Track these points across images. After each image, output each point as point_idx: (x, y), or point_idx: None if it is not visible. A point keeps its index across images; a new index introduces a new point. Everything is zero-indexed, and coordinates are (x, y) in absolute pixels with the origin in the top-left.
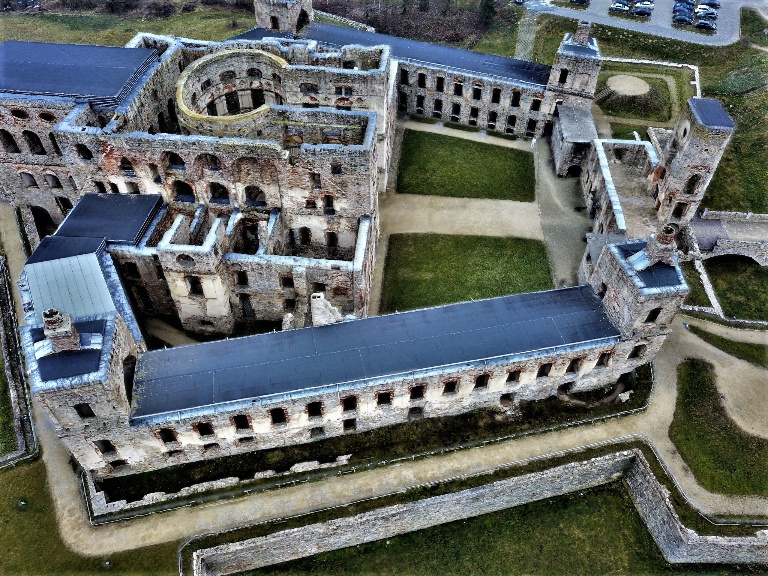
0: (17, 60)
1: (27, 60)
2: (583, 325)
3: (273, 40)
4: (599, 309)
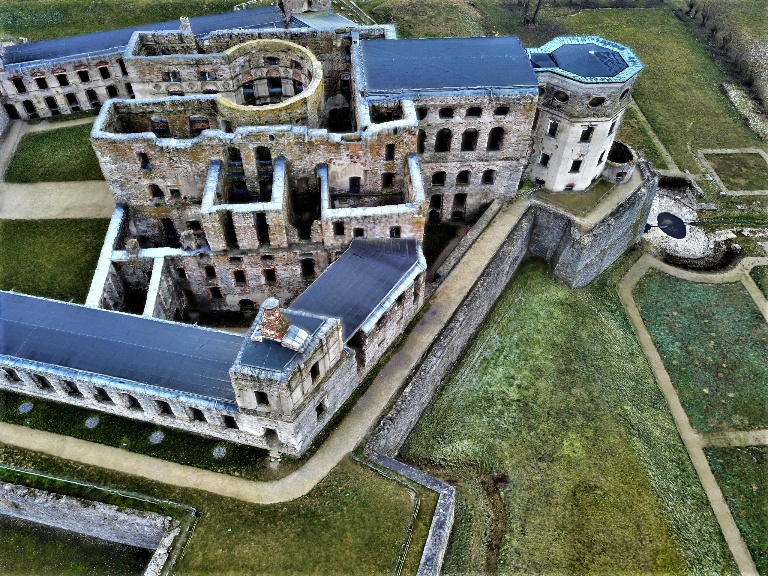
0: (489, 58)
1: (480, 59)
2: (24, 47)
3: (242, 131)
4: (7, 53)
